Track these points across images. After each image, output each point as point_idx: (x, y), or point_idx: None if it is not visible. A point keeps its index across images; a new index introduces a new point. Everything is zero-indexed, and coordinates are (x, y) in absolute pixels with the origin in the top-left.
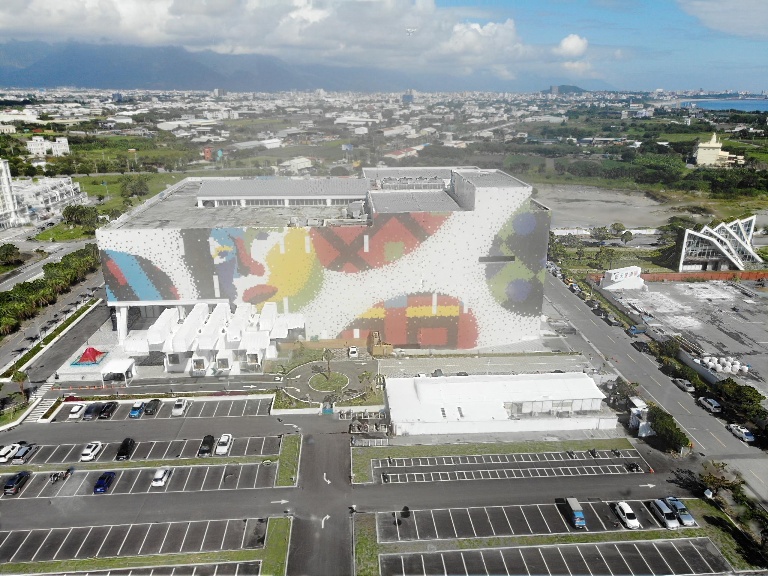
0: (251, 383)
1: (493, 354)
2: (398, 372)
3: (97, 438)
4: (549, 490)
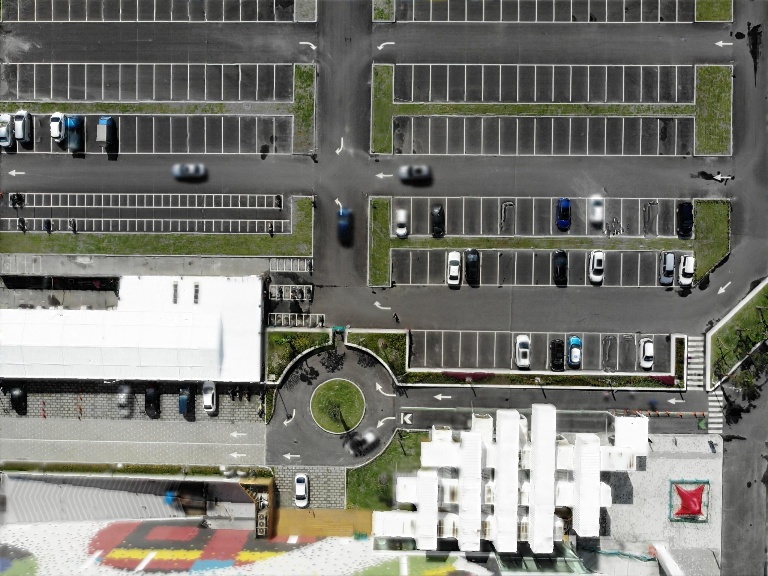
0: (443, 405)
1: (94, 470)
2: (242, 427)
3: (603, 297)
4: (119, 173)
